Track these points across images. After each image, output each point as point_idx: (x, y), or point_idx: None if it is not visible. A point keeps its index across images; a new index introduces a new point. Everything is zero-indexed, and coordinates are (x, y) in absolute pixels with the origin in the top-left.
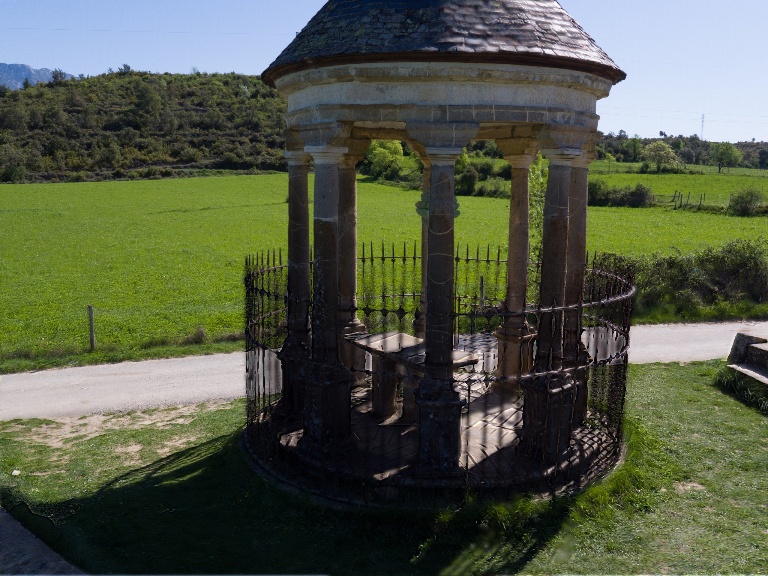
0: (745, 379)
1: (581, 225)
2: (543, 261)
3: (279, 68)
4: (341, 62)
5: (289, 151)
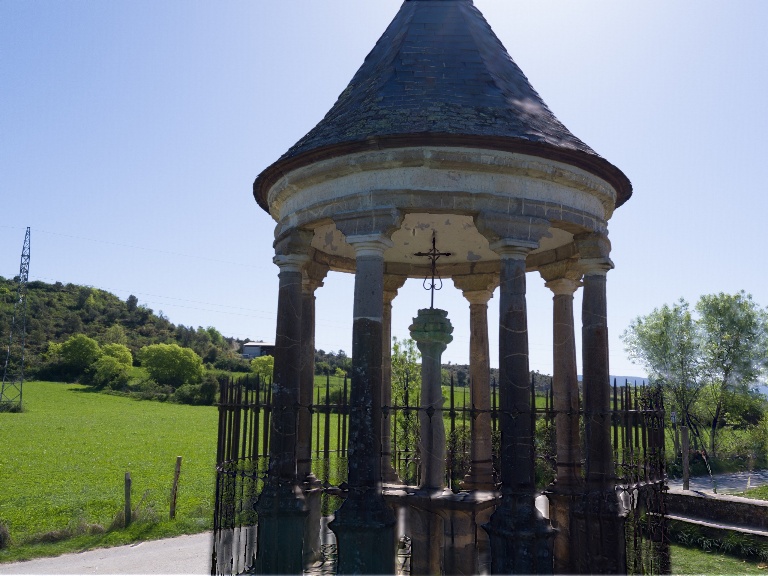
0: (673, 523)
1: (574, 352)
2: (591, 373)
3: (315, 152)
4: (416, 143)
5: (287, 254)
